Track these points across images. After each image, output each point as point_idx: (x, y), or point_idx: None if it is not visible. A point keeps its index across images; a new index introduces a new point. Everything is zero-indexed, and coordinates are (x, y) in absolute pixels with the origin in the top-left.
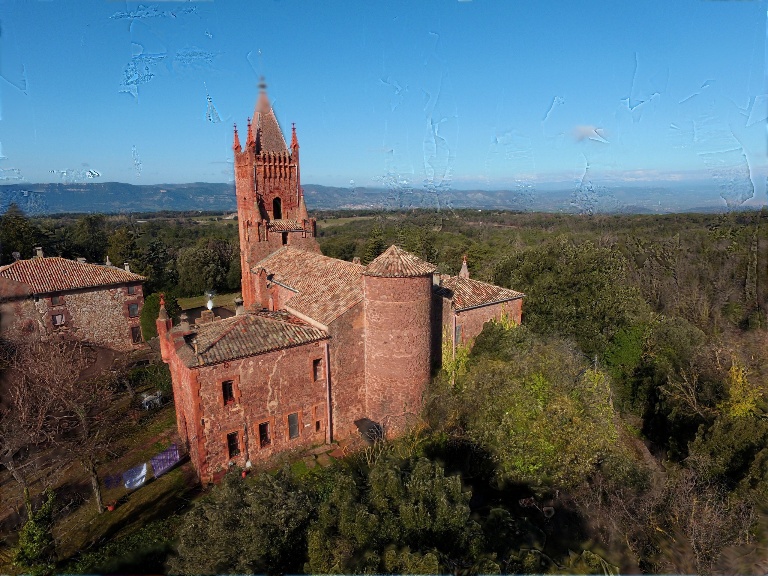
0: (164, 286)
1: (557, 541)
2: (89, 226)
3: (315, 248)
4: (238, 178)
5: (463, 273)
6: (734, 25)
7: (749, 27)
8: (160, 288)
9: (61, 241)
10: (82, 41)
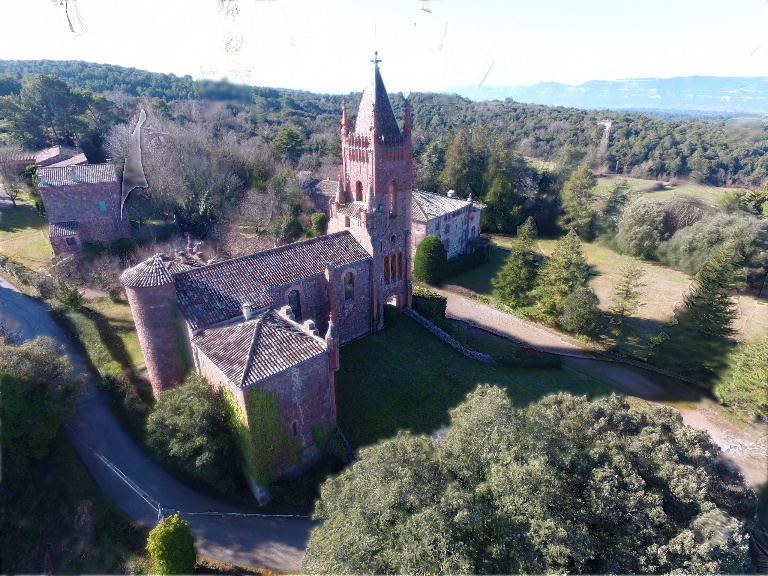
0: (605, 233)
1: None
2: (569, 158)
3: (368, 240)
4: None
5: None
6: None
7: None
8: (601, 234)
9: (534, 169)
10: None
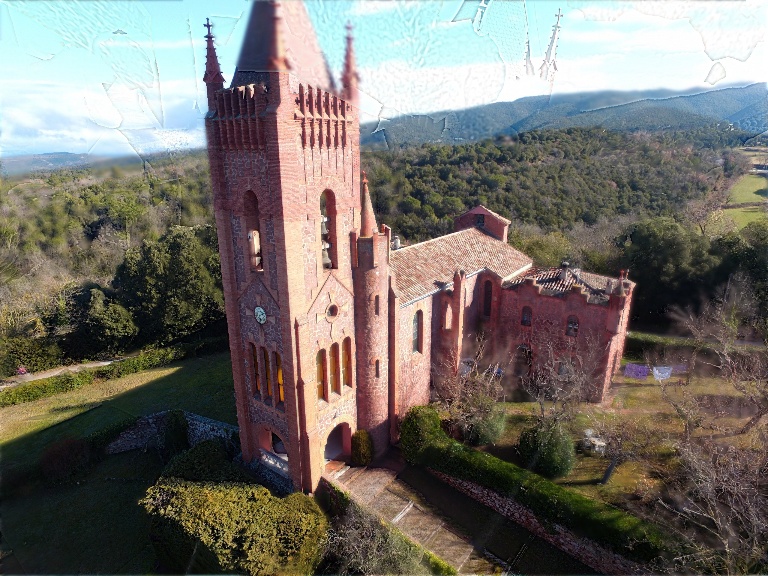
0: None
1: (571, 268)
2: None
3: None
4: (299, 145)
5: None
6: (165, 23)
7: (181, 32)
8: None
9: None
10: None
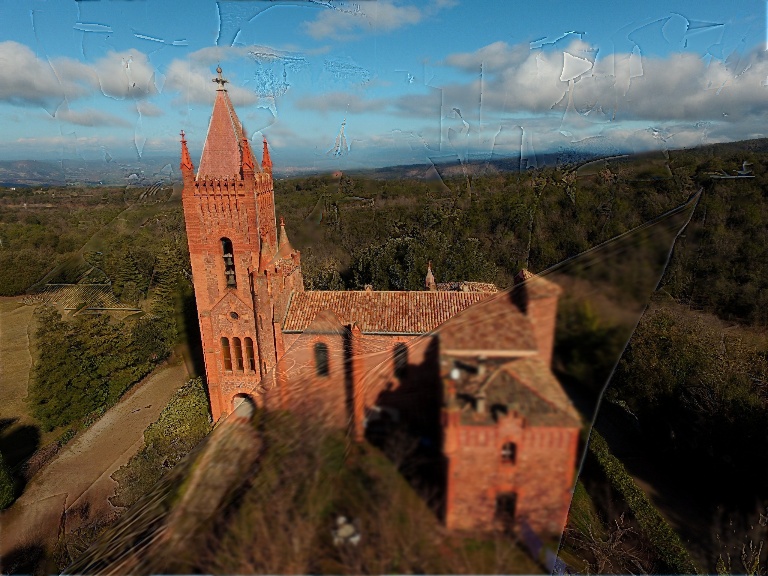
0: None
1: None
2: None
3: (301, 285)
4: (199, 210)
5: (432, 278)
6: (463, 72)
7: (474, 76)
8: None
9: None
10: (238, 19)
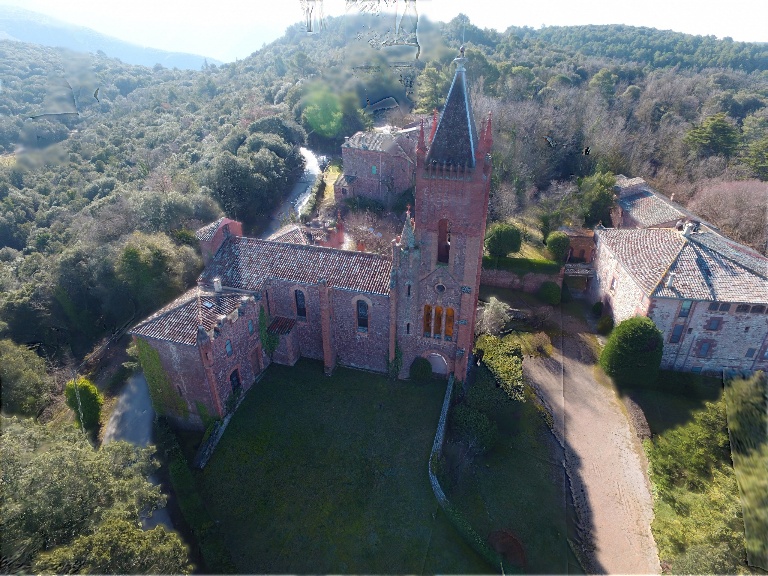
0: None
1: None
2: None
3: None
4: None
5: None
6: None
7: None
8: None
9: None
10: None
